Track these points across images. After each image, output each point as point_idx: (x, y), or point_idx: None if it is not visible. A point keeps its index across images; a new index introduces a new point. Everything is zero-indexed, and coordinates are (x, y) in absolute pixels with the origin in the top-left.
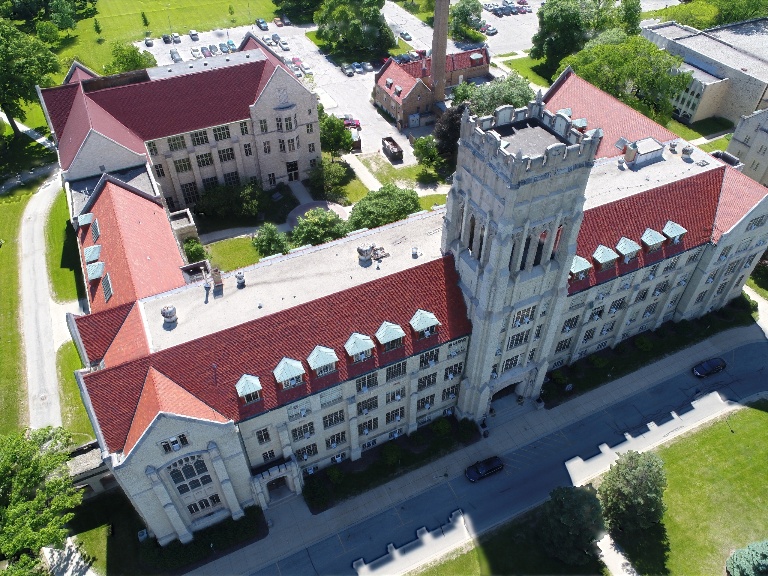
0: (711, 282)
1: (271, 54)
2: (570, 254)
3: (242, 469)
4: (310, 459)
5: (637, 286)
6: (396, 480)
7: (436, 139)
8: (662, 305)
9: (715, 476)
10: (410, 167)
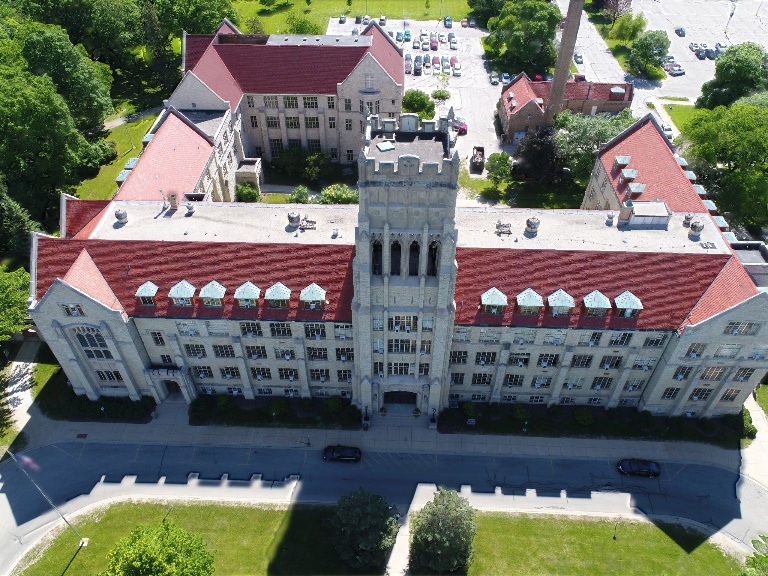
0: (680, 379)
1: (389, 44)
2: (443, 274)
3: (136, 358)
4: (207, 380)
5: (571, 347)
6: (267, 429)
7: (514, 158)
8: (616, 383)
9: (558, 567)
10: (484, 180)
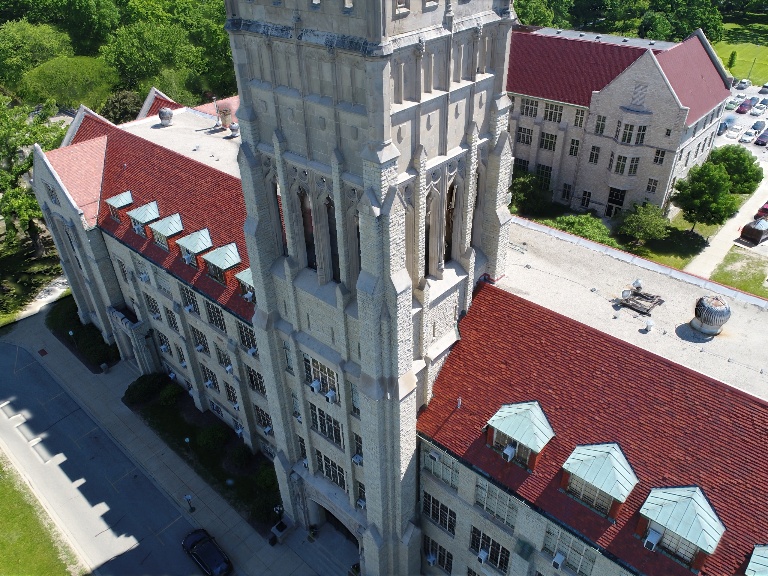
0: None
1: (712, 66)
2: (361, 292)
3: None
4: None
5: None
6: (176, 456)
7: None
8: None
9: None
10: None
